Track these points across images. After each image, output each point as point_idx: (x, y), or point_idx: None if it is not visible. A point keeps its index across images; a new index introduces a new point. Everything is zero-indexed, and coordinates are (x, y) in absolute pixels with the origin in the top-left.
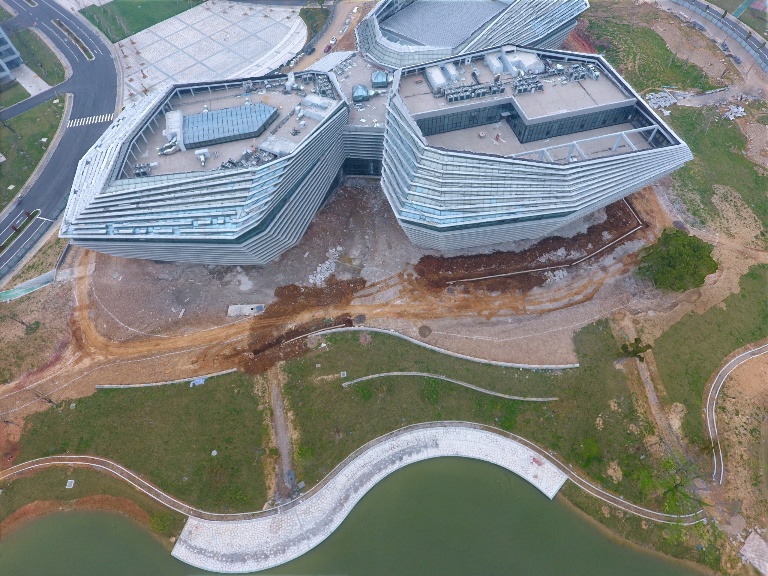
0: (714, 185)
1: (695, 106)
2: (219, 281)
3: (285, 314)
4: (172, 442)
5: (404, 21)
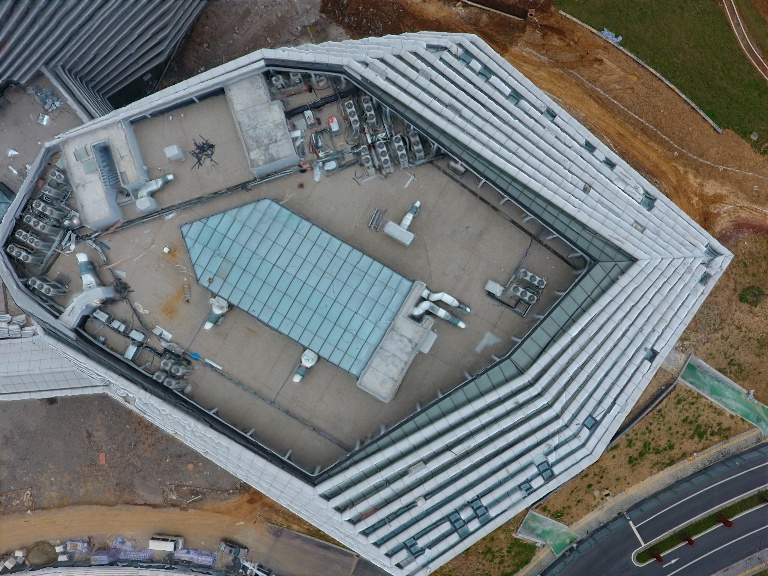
0: None
1: None
2: None
3: None
4: (675, 2)
5: None
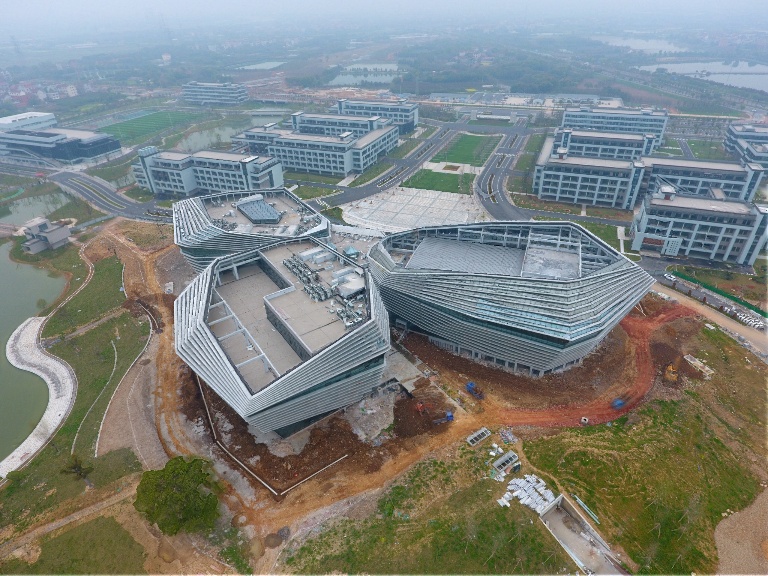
0: (368, 575)
1: (571, 556)
2: (192, 273)
3: (165, 302)
4: None
5: (440, 244)
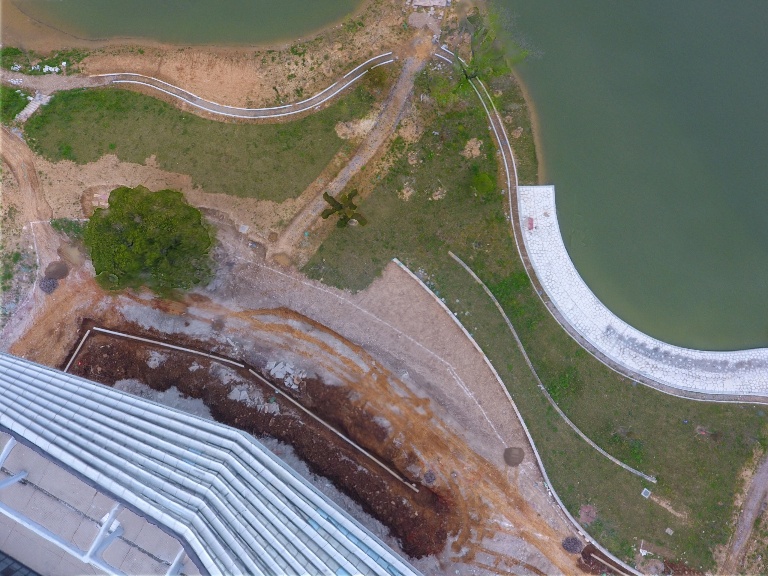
0: None
1: None
2: None
3: None
4: None
5: None
